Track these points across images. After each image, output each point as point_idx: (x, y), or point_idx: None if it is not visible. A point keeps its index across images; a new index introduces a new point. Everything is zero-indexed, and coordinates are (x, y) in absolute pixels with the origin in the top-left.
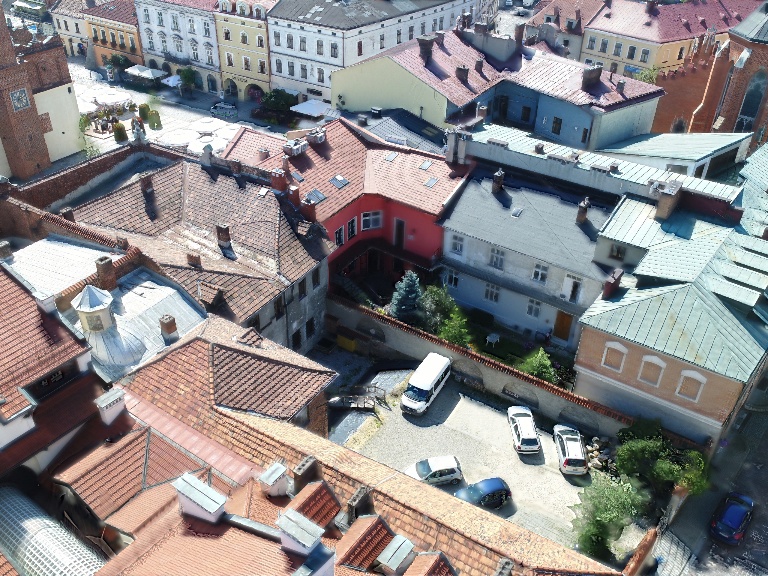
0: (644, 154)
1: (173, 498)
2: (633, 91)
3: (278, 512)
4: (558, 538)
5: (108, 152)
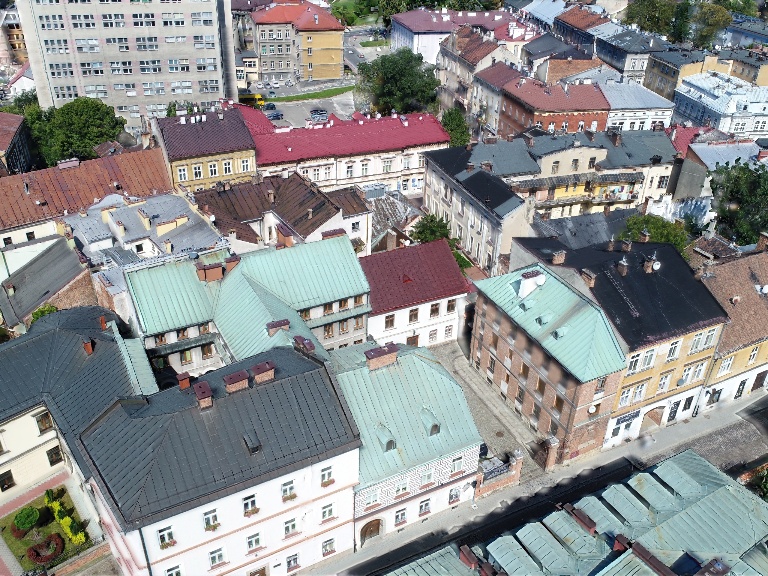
0: None
1: None
2: None
3: None
4: None
5: None
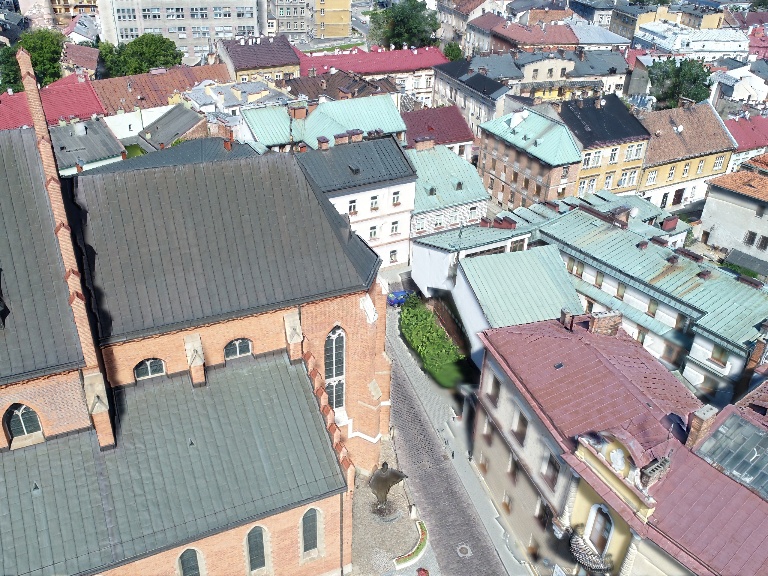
0: (574, 289)
1: None
2: (542, 325)
3: None
4: None
5: None
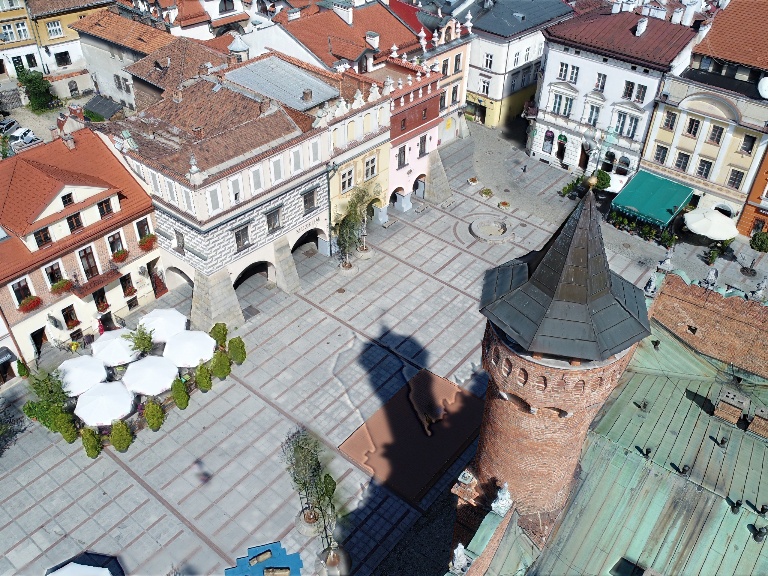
0: None
1: (214, 38)
2: None
3: (175, 3)
4: (53, 114)
5: (235, 165)
